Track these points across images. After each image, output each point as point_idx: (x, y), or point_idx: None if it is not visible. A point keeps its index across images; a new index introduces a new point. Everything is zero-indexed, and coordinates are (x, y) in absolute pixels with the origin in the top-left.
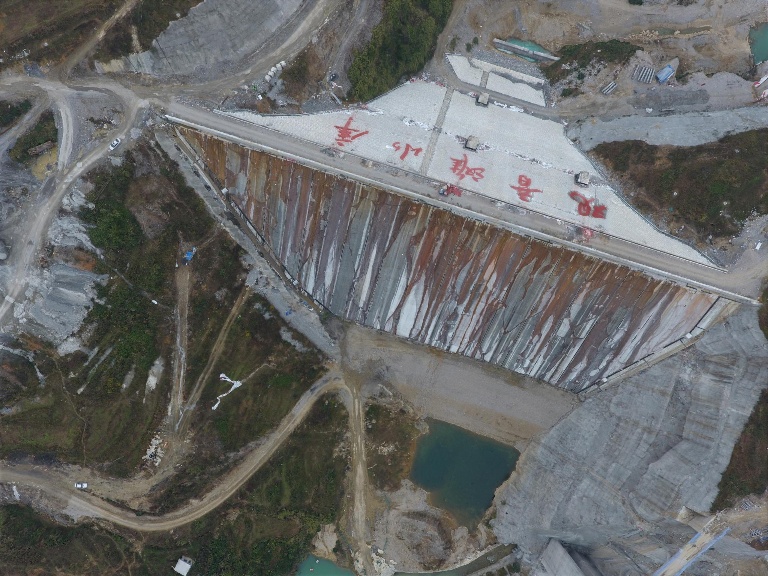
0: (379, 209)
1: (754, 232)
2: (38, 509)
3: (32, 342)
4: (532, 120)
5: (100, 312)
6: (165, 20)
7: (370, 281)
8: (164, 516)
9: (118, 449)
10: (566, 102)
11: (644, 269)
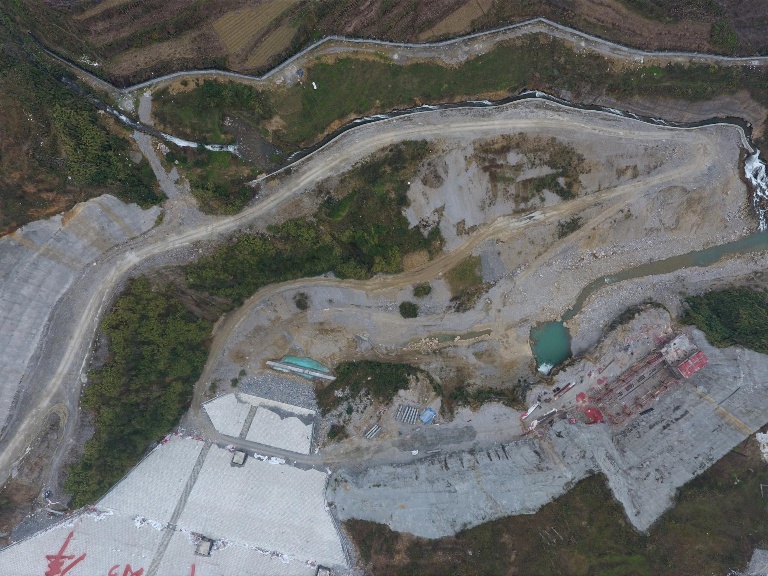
0: None
1: None
2: None
3: None
4: (292, 475)
5: None
6: None
7: None
8: None
9: None
10: (330, 448)
11: None
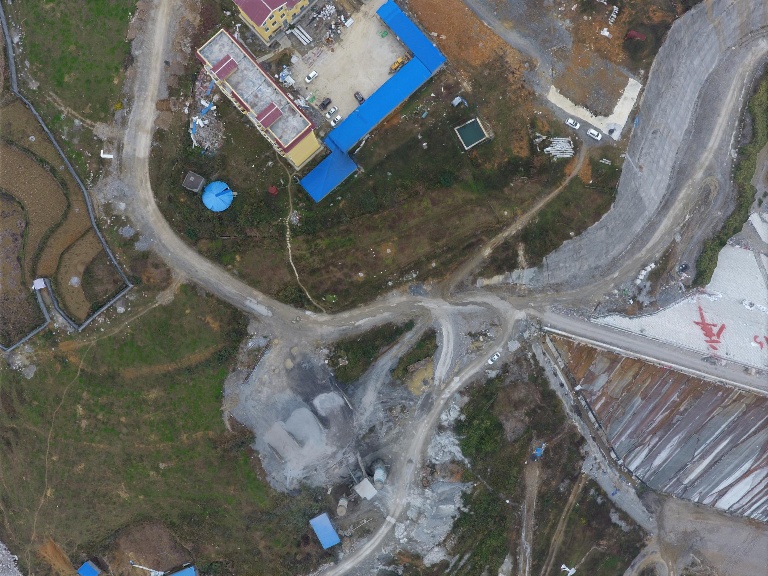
0: (750, 410)
1: None
2: None
3: (404, 557)
4: None
5: (468, 522)
6: (561, 240)
7: (707, 464)
8: None
9: None
10: None
11: None
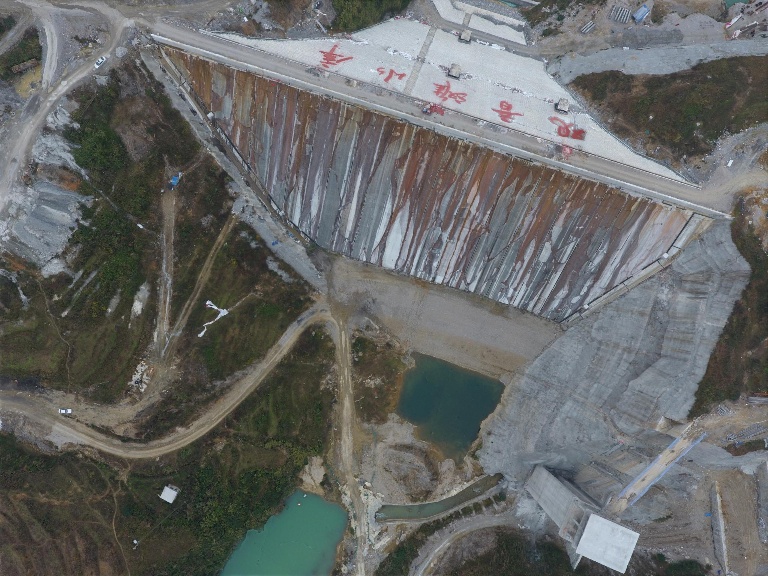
0: (364, 130)
1: (726, 150)
2: (21, 437)
3: (15, 262)
4: (513, 57)
5: (85, 233)
6: None
7: (356, 209)
8: (150, 443)
9: (103, 374)
10: (546, 41)
11: (621, 186)
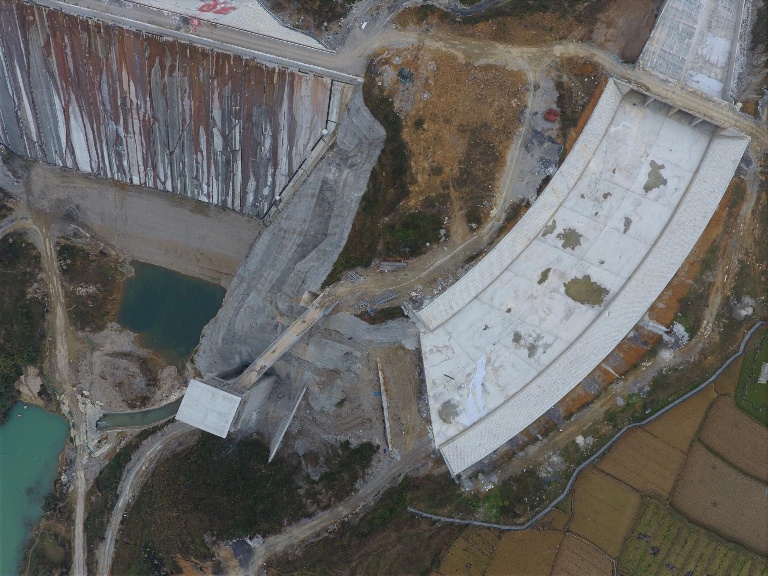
0: None
1: (360, 12)
2: None
3: None
4: None
5: None
6: None
7: (30, 108)
8: None
9: None
10: None
11: (255, 57)
